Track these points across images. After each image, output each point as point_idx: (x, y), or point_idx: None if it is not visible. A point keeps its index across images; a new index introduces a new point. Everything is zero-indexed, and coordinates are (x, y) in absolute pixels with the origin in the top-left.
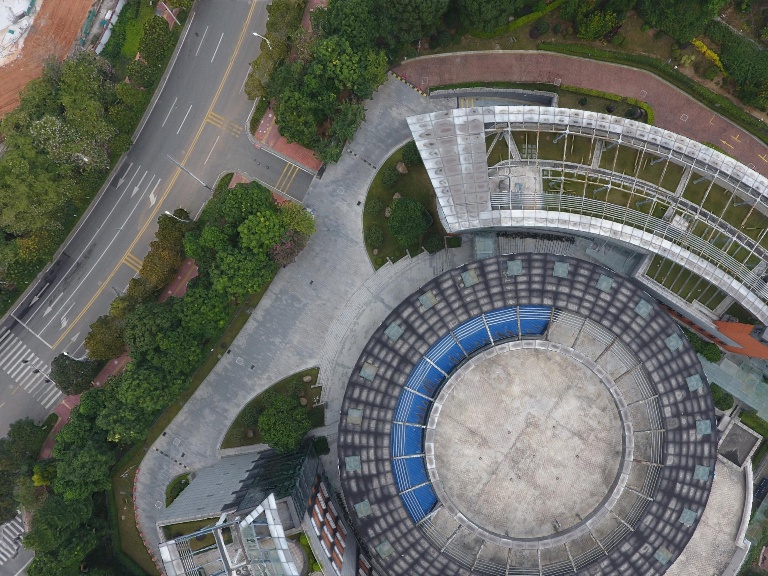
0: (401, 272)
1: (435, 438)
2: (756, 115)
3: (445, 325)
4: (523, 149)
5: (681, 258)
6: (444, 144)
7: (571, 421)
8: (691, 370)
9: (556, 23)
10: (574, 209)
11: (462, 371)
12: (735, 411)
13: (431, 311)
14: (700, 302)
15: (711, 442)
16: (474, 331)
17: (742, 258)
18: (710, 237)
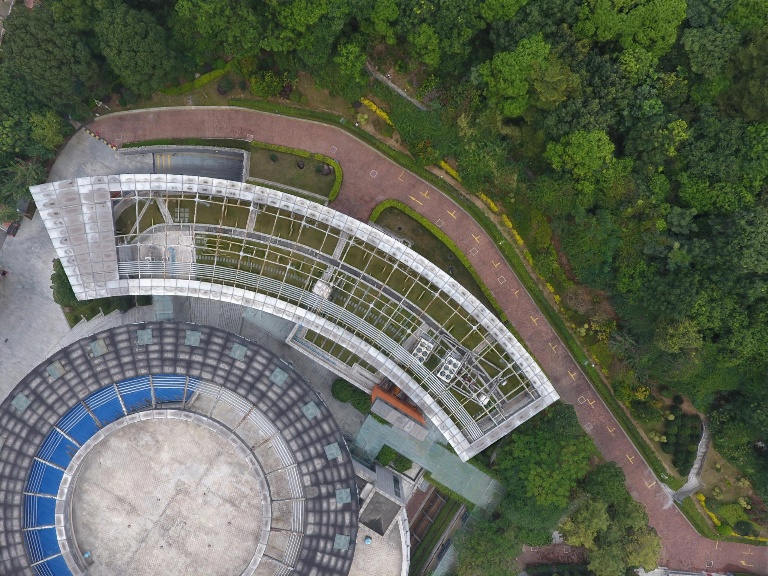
0: (92, 330)
1: (82, 506)
2: (436, 173)
3: (75, 395)
4: (175, 213)
5: (316, 326)
6: (69, 213)
7: (223, 488)
8: (330, 438)
9: (241, 80)
10: (205, 277)
11: (92, 442)
12: (422, 471)
13: (60, 381)
14: (361, 365)
15: (352, 511)
16: (107, 400)
17: (403, 321)
18: (346, 304)
